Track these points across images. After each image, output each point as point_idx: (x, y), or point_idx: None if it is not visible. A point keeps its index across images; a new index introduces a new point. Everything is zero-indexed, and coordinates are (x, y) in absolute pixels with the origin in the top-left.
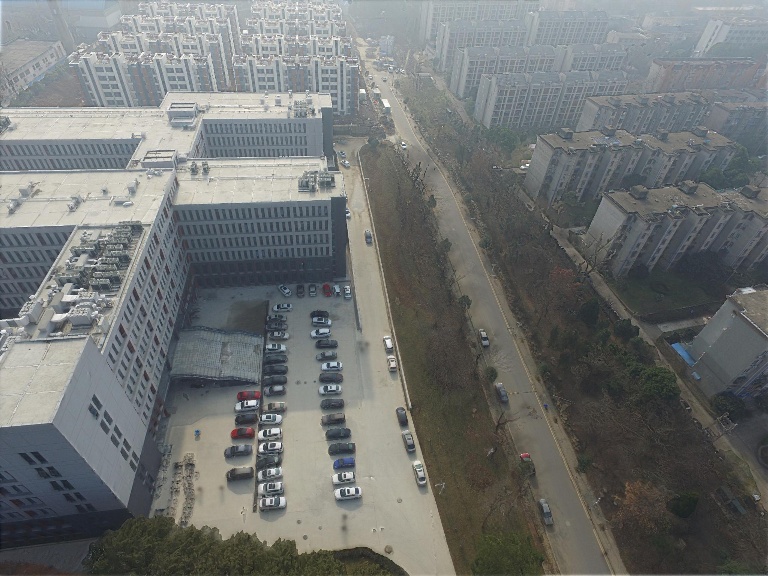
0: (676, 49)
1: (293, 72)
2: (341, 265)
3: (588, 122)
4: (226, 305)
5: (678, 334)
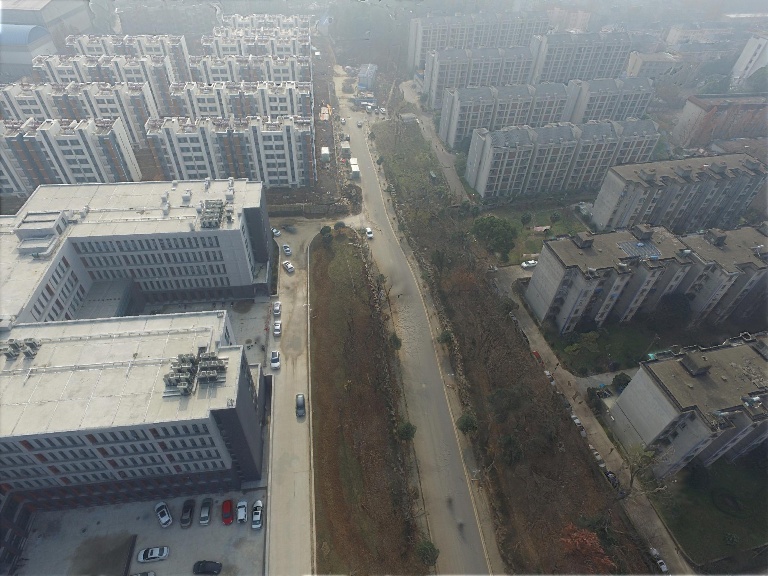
0: (709, 70)
1: (225, 140)
2: (250, 470)
3: (611, 199)
4: (69, 548)
5: None
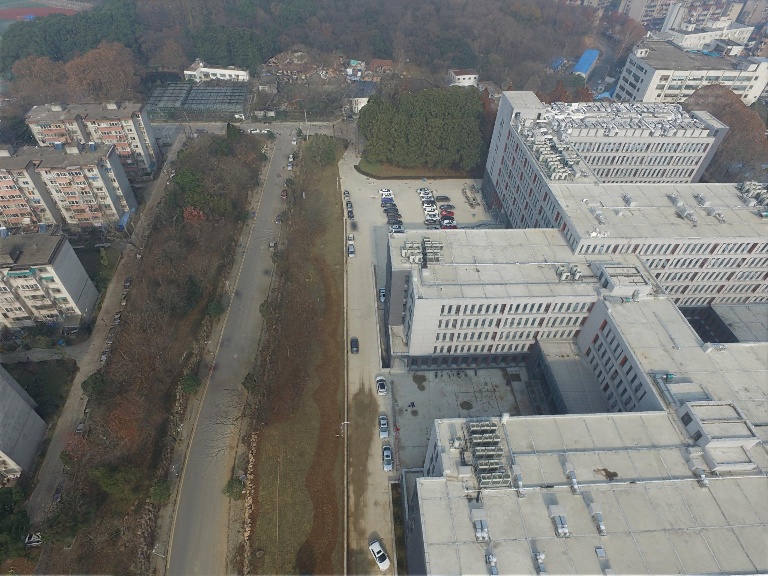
0: None
1: None
2: None
3: None
4: None
5: None
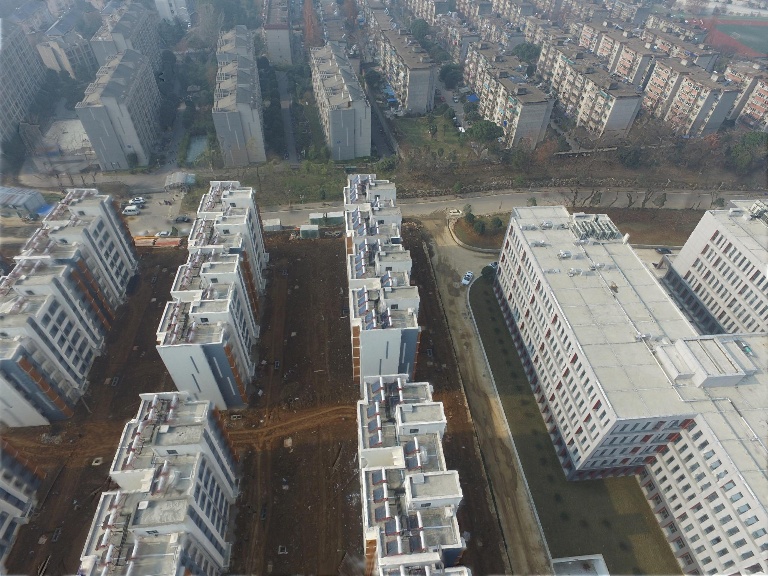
0: None
1: None
2: None
3: (423, 88)
4: None
5: (674, 133)
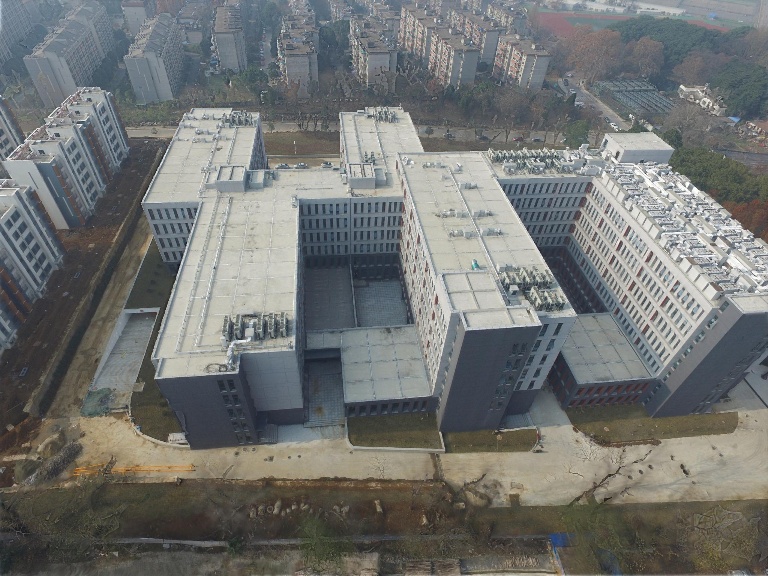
0: None
1: (86, 133)
2: None
3: (230, 49)
4: None
5: None
